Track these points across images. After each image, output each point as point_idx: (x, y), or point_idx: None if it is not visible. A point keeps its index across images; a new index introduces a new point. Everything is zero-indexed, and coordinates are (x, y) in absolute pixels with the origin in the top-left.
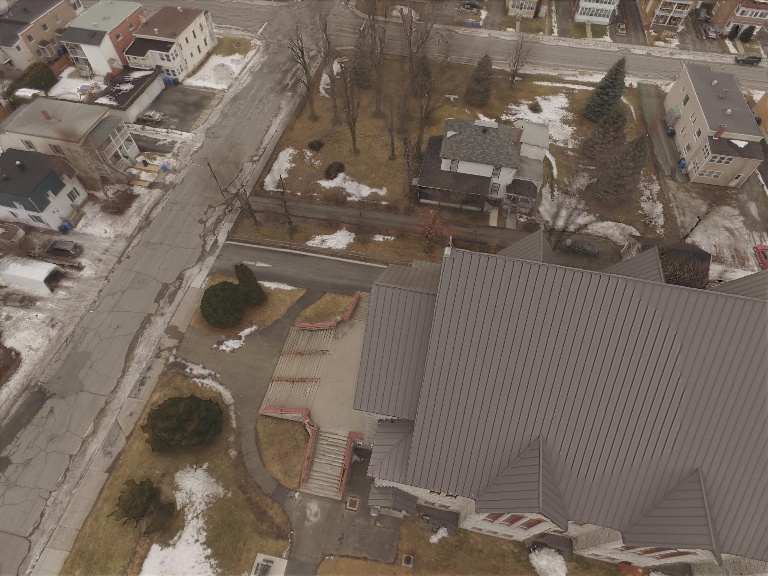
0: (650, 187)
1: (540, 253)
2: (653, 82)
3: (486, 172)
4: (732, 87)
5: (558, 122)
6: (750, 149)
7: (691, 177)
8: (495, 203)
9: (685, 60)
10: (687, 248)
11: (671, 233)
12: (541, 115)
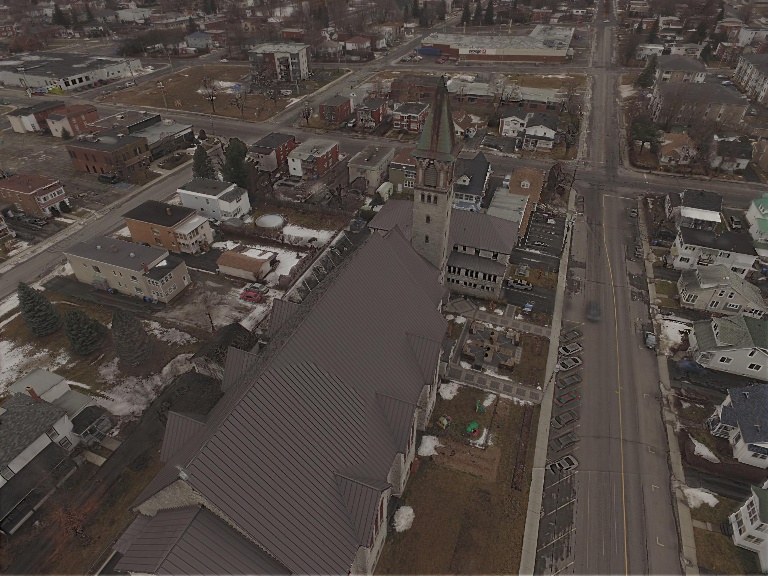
0: (152, 328)
1: (191, 421)
2: (51, 277)
3: (43, 443)
4: (112, 242)
5: (26, 360)
6: (171, 262)
7: (164, 301)
8: (78, 451)
9: (49, 248)
10: (224, 332)
11: (201, 335)
12: (2, 370)
